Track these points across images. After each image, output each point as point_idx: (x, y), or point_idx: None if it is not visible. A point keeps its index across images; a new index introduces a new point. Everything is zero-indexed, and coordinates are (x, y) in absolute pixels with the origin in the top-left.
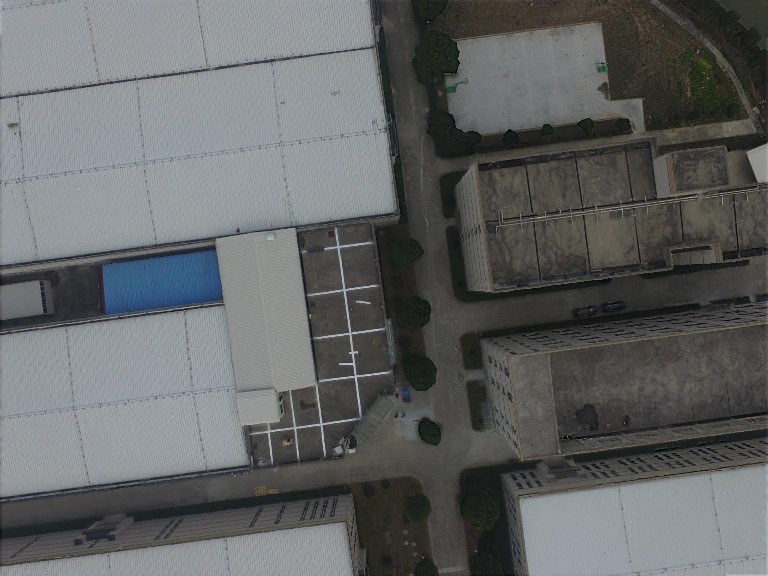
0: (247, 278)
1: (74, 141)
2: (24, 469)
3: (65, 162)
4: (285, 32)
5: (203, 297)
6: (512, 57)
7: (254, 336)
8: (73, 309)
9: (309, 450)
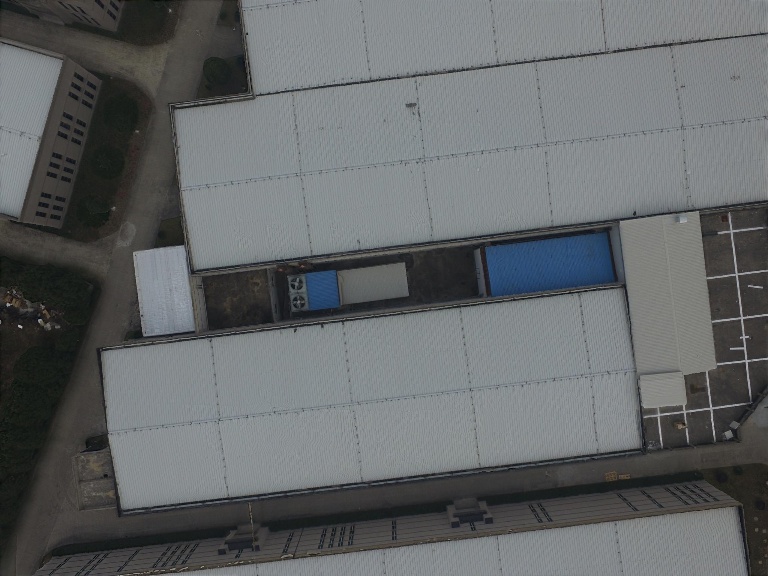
0: (653, 261)
1: (474, 122)
2: (408, 451)
3: (466, 143)
4: (685, 16)
5: (592, 280)
6: None
7: (659, 319)
8: (427, 292)
9: (699, 434)
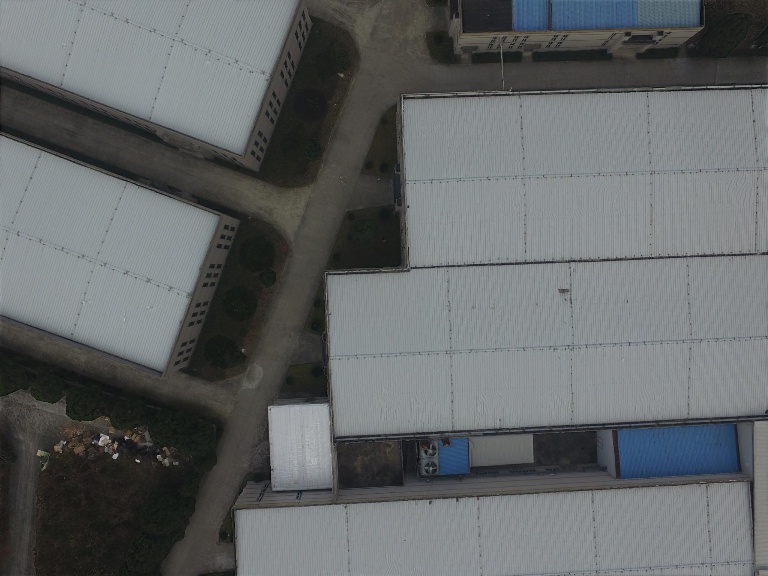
0: None
1: (624, 313)
2: None
3: (614, 333)
4: None
5: (718, 470)
6: None
7: None
8: (546, 454)
9: None
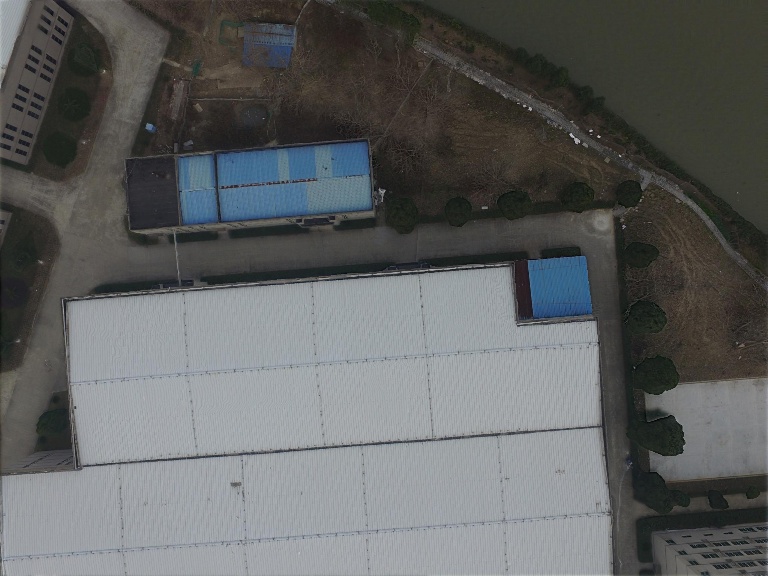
0: None
1: (297, 505)
2: None
3: (288, 527)
4: (513, 408)
5: None
6: (715, 405)
7: None
8: None
9: None
